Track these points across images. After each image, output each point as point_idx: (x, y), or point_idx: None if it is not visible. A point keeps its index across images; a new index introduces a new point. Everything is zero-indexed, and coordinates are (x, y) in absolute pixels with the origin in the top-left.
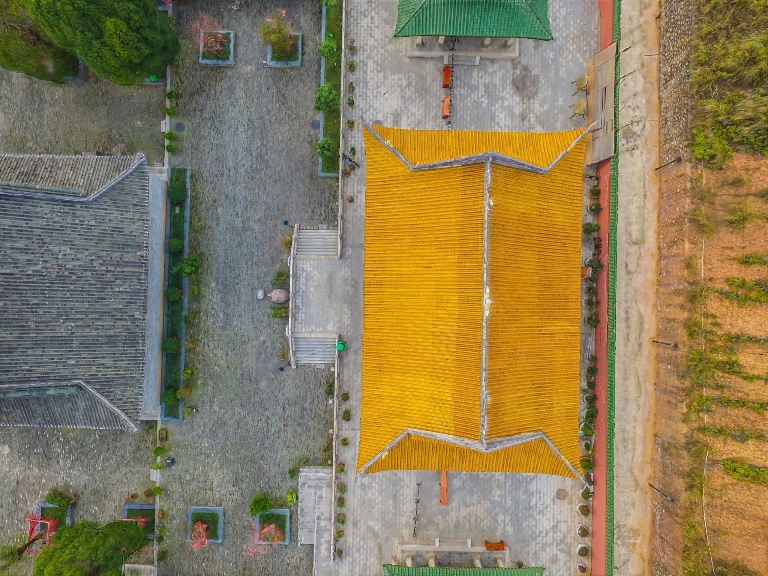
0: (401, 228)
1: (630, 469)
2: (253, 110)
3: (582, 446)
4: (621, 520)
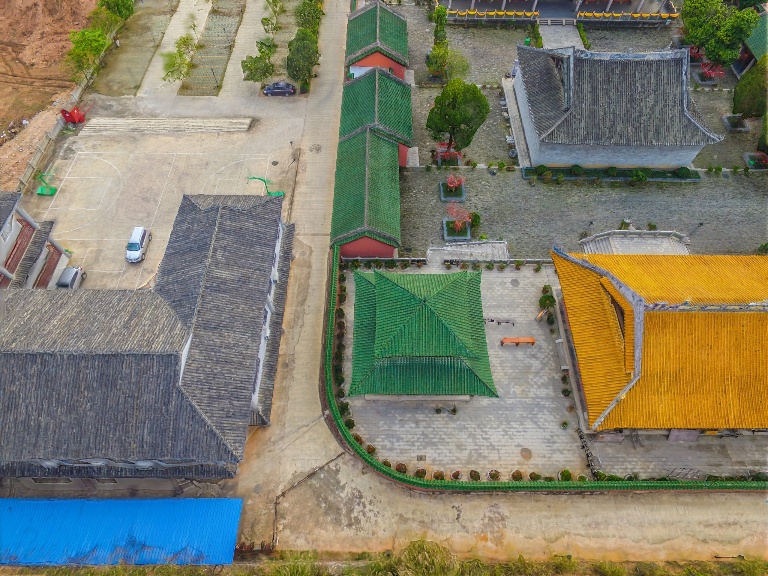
0: (760, 273)
1: (567, 532)
2: (761, 216)
3: (580, 474)
4: (510, 522)
